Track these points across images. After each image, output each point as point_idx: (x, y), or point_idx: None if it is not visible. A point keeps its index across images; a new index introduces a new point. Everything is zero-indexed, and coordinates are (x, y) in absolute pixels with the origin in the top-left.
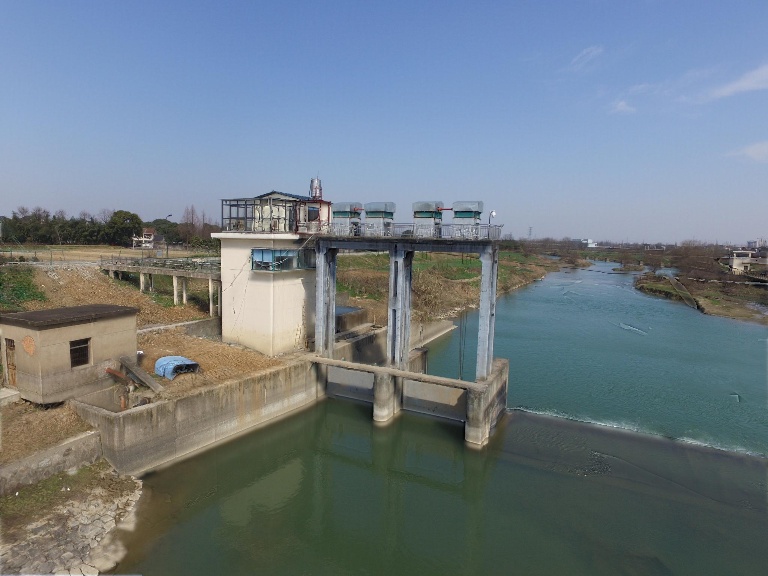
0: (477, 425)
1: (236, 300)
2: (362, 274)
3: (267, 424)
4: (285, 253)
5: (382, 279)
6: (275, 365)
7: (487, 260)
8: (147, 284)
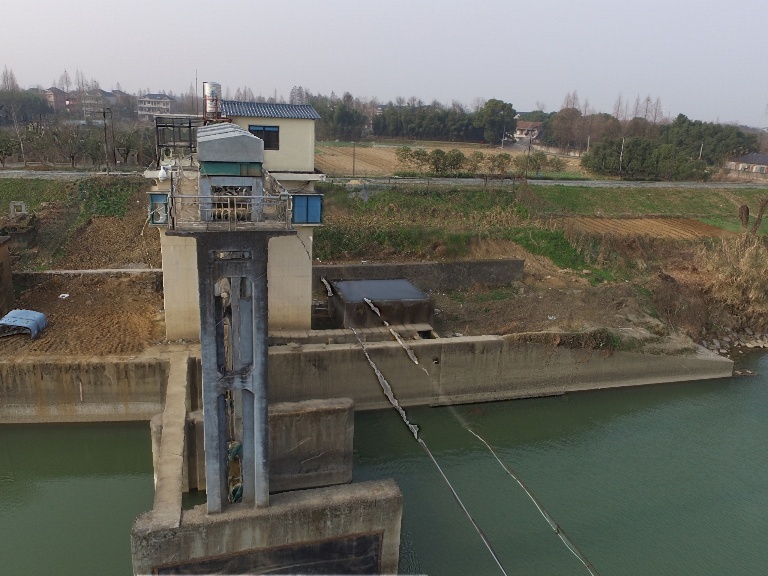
0: None
1: None
2: (651, 227)
3: (88, 426)
4: None
5: (677, 243)
6: (117, 355)
7: None
8: None
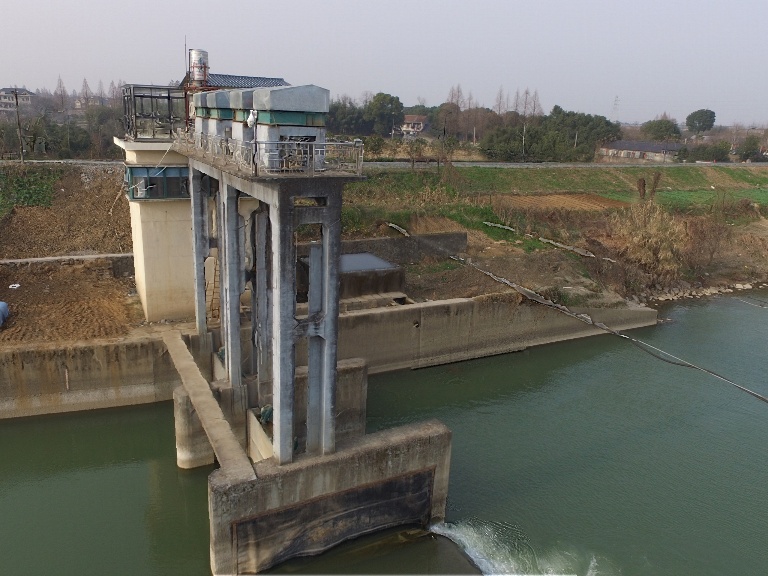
0: (212, 544)
1: (134, 234)
2: (564, 202)
3: (75, 416)
4: (161, 172)
5: (589, 214)
6: (104, 338)
7: (275, 222)
8: None
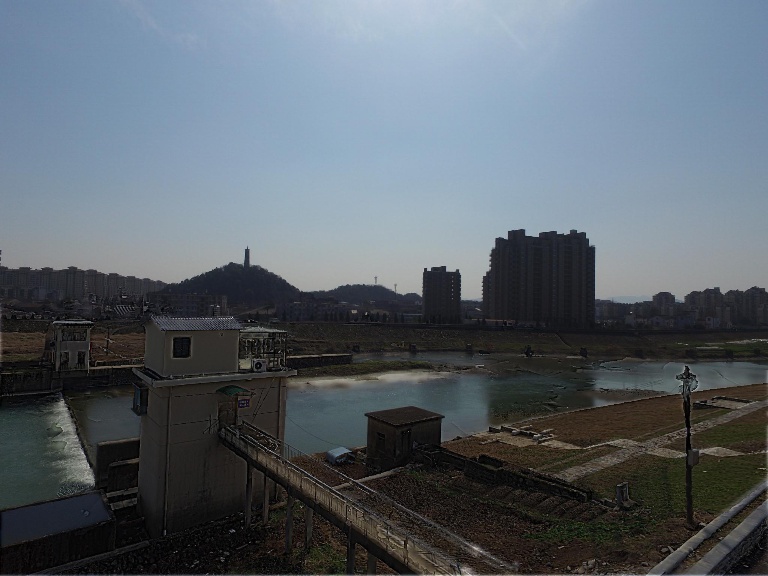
0: None
1: None
2: None
3: None
4: None
5: None
6: None
7: None
8: None
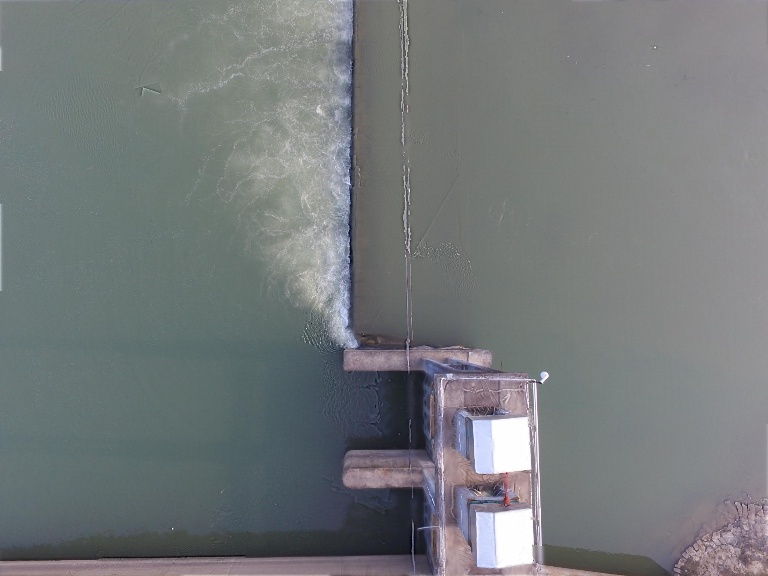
0: None
1: None
2: None
3: None
4: None
5: None
6: None
7: None
8: None
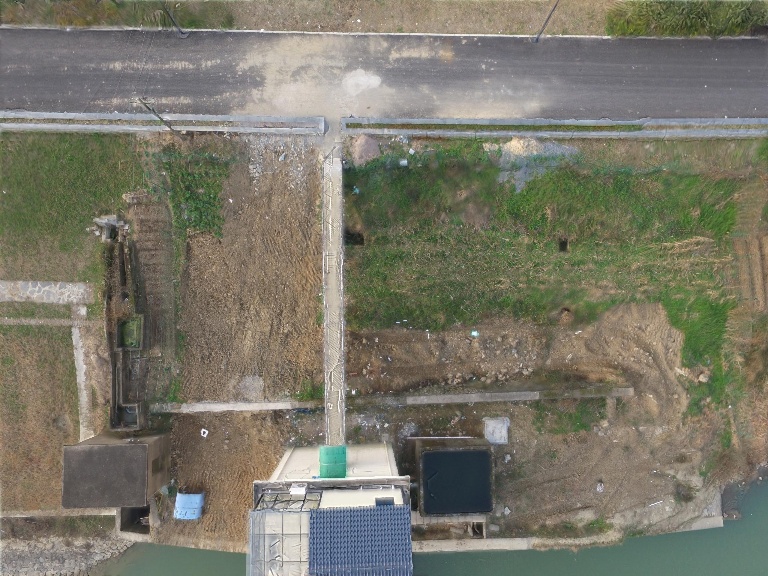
0: None
1: None
2: None
3: None
4: None
5: None
6: None
7: None
8: (361, 222)
